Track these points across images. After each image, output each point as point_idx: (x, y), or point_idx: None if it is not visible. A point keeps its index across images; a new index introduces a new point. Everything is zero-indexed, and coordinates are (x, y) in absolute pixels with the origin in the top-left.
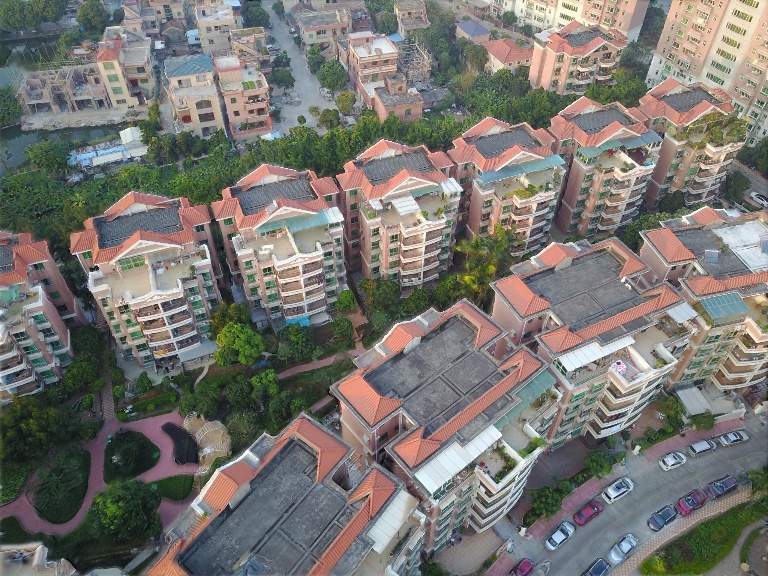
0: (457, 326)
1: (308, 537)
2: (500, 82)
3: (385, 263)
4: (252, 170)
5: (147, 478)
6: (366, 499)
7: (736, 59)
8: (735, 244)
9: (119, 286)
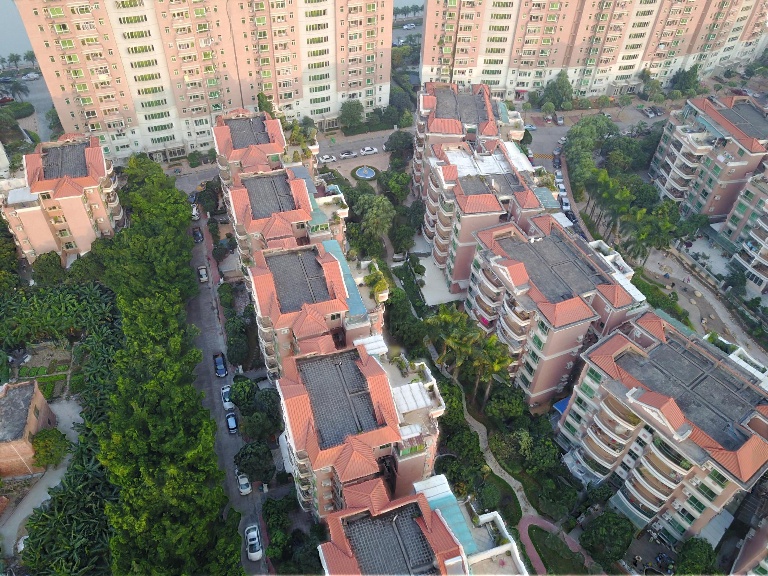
0: (622, 366)
1: None
2: (6, 288)
3: (431, 465)
4: None
5: None
6: None
7: (163, 88)
8: (474, 171)
9: None
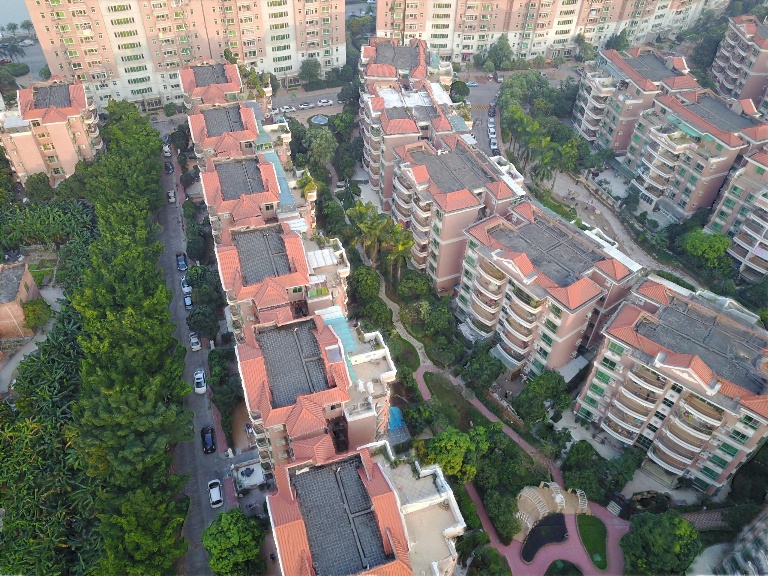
0: (494, 237)
1: (703, 327)
2: (3, 202)
3: None
4: (133, 447)
5: (587, 570)
6: (667, 292)
7: (140, 44)
8: (400, 104)
9: (426, 554)
